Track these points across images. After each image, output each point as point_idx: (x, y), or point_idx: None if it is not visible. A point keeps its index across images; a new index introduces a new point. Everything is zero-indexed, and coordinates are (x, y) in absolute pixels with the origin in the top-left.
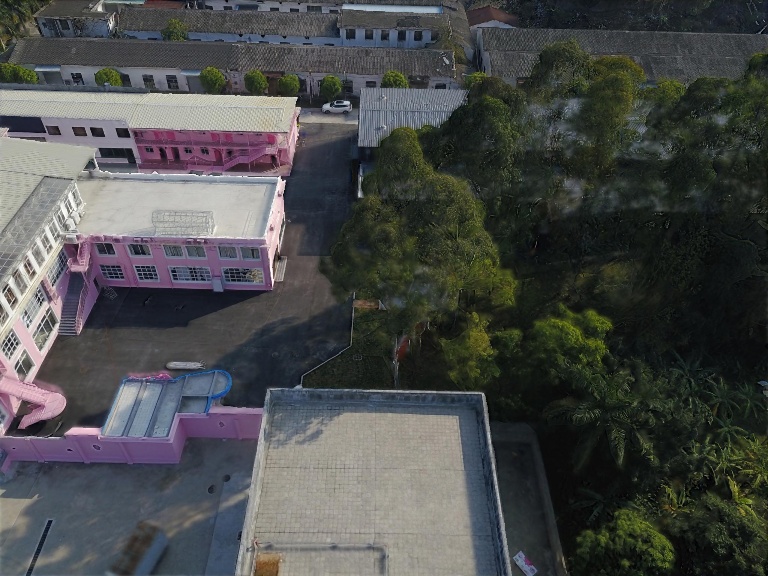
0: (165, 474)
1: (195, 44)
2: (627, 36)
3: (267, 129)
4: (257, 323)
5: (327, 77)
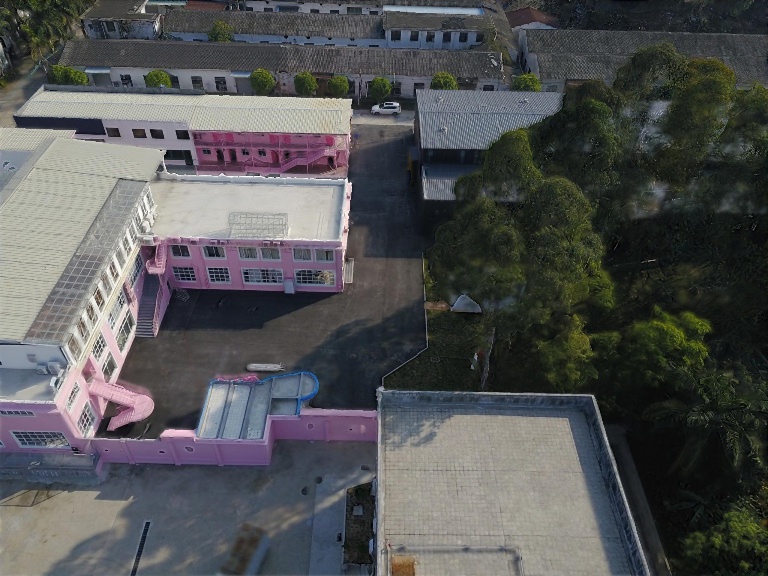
0: (257, 476)
1: (243, 46)
2: (671, 37)
3: (327, 131)
4: (331, 325)
5: (377, 79)
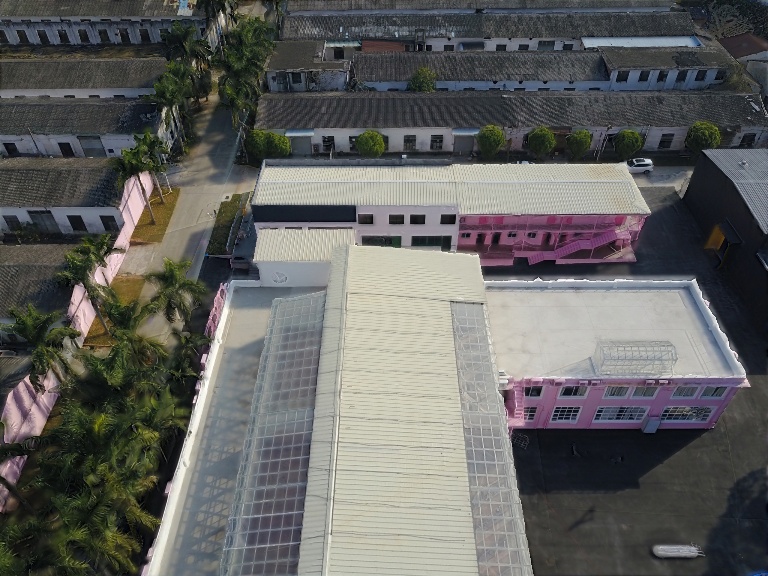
0: None
1: (460, 97)
2: None
3: (624, 210)
4: (725, 480)
5: (627, 132)
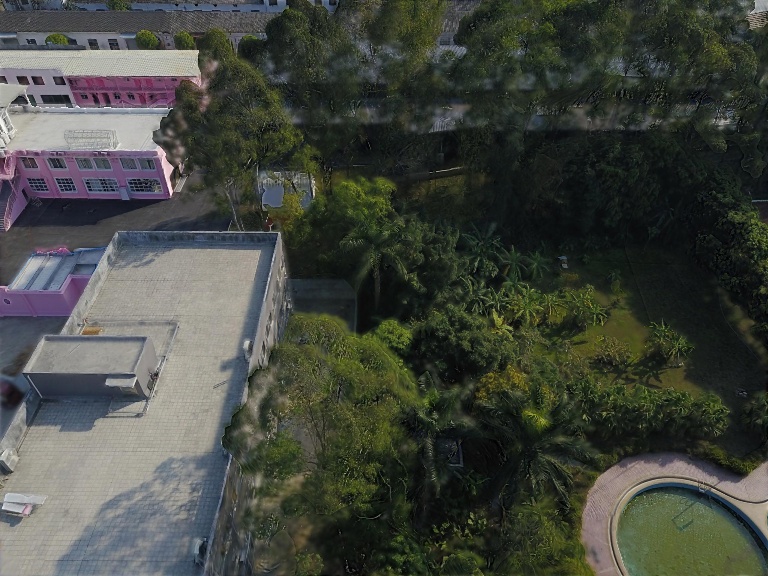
0: (61, 323)
1: (133, 12)
2: None
3: (179, 74)
4: (153, 221)
5: None
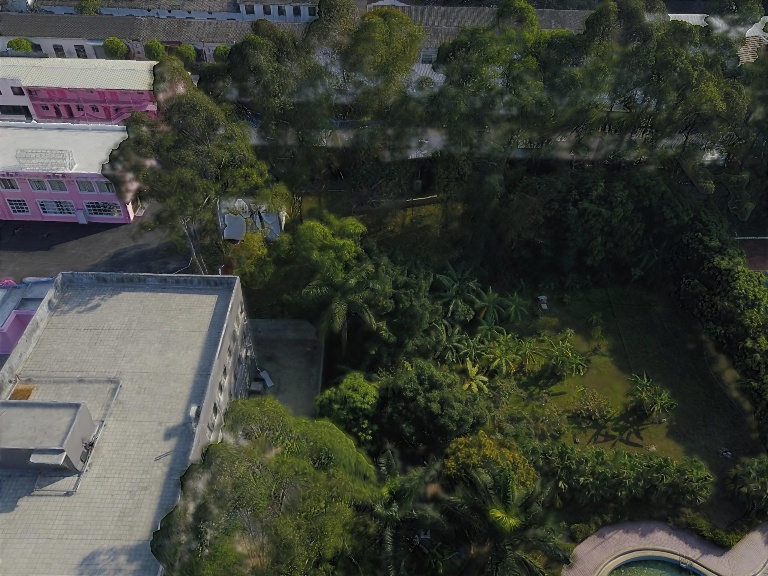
0: (4, 362)
1: (102, 17)
2: None
3: (146, 87)
4: (111, 248)
5: (219, 46)
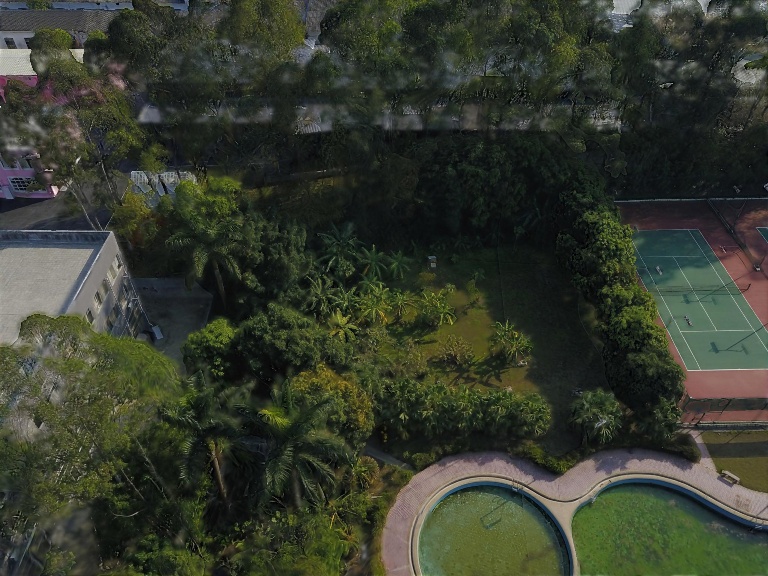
0: None
1: (51, 11)
2: None
3: None
4: (32, 220)
5: None
